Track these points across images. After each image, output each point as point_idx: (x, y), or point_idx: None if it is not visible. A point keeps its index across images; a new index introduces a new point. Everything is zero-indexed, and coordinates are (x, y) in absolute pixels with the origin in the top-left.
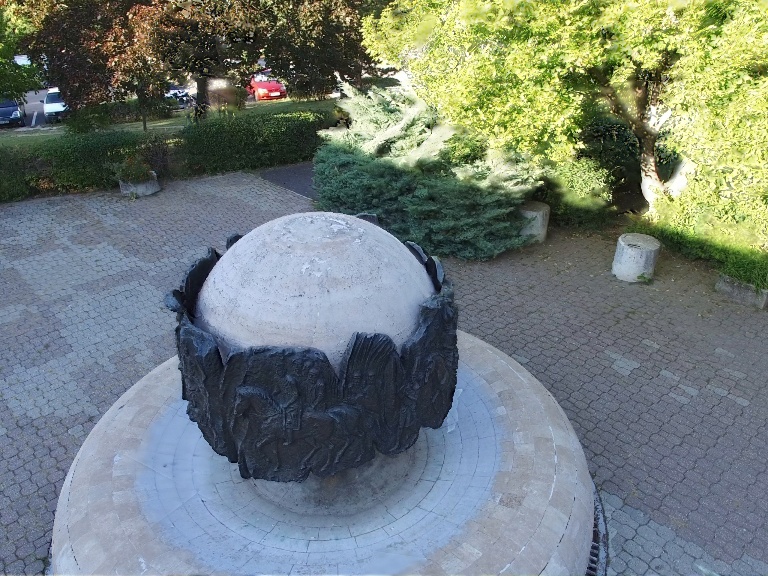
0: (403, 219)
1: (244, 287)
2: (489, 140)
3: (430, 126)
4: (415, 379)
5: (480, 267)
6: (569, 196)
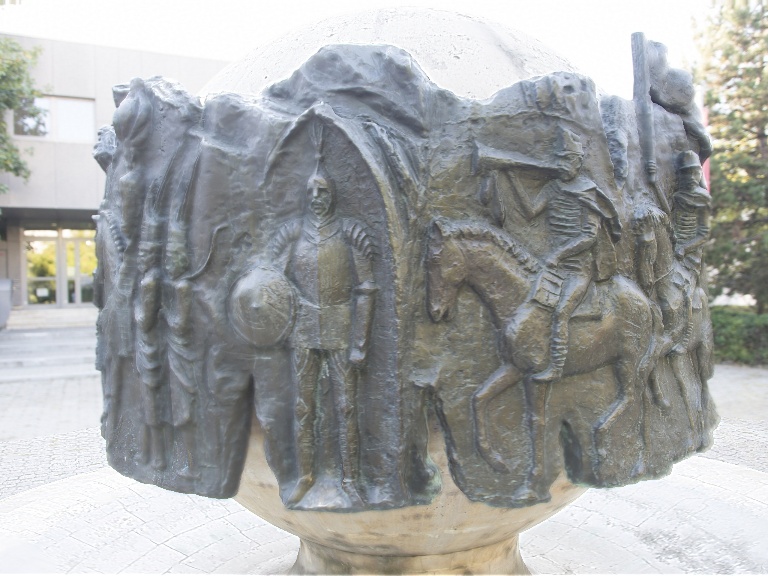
0: None
1: None
2: None
3: None
4: None
5: None
6: None
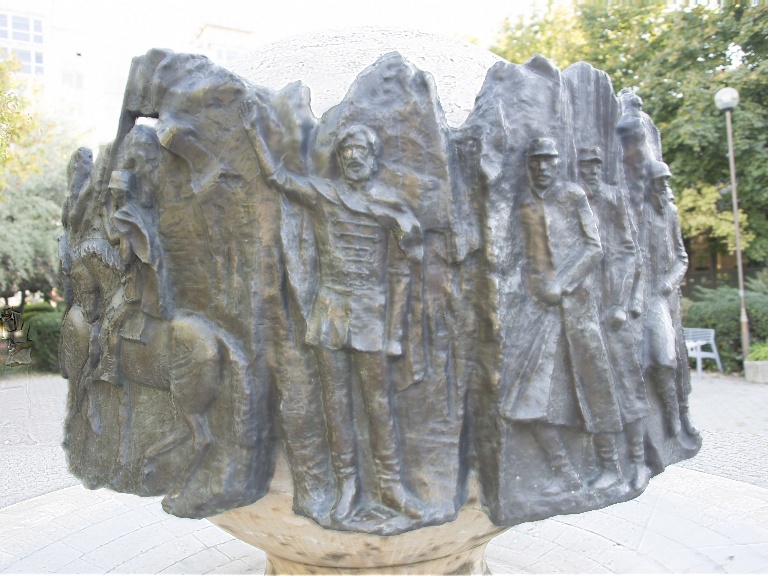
0: None
1: None
2: None
3: None
4: None
5: None
6: None
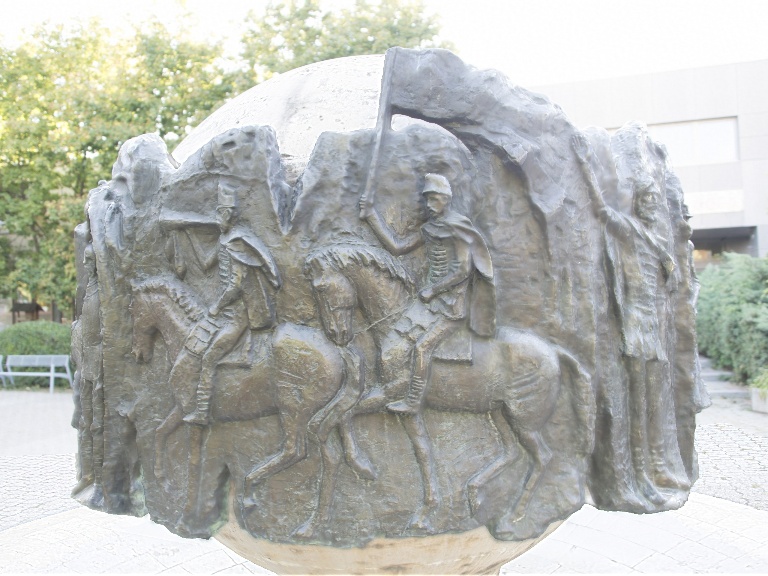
0: None
1: None
2: None
3: None
4: None
5: None
6: None
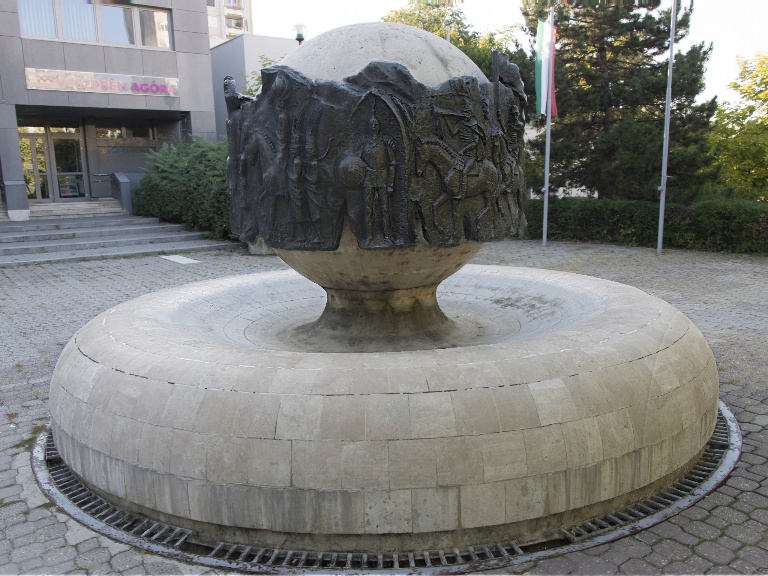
0: None
1: None
2: None
3: None
4: (242, 148)
5: None
6: None
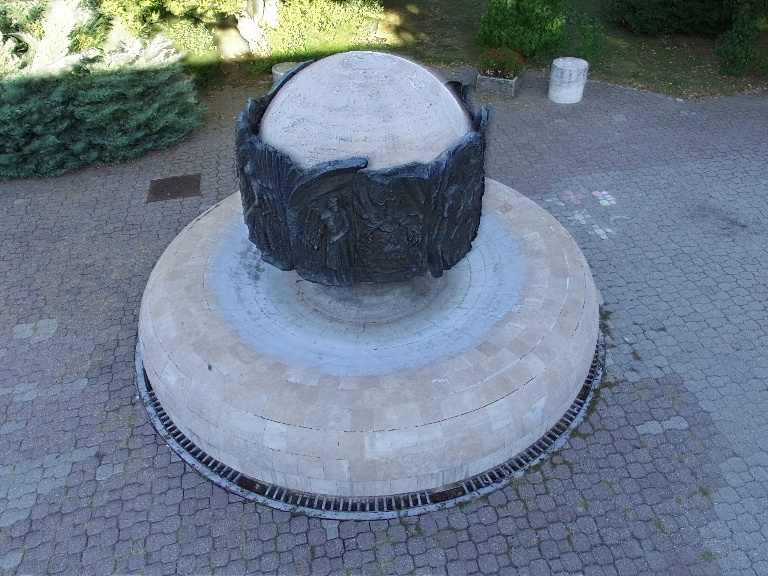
0: (71, 139)
1: (389, 121)
2: (169, 7)
3: (21, 28)
4: None
5: (186, 147)
6: (191, 58)
